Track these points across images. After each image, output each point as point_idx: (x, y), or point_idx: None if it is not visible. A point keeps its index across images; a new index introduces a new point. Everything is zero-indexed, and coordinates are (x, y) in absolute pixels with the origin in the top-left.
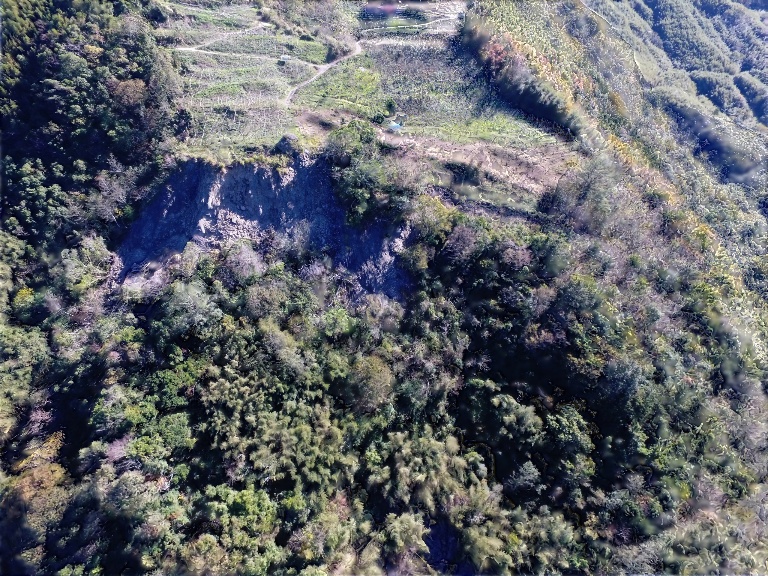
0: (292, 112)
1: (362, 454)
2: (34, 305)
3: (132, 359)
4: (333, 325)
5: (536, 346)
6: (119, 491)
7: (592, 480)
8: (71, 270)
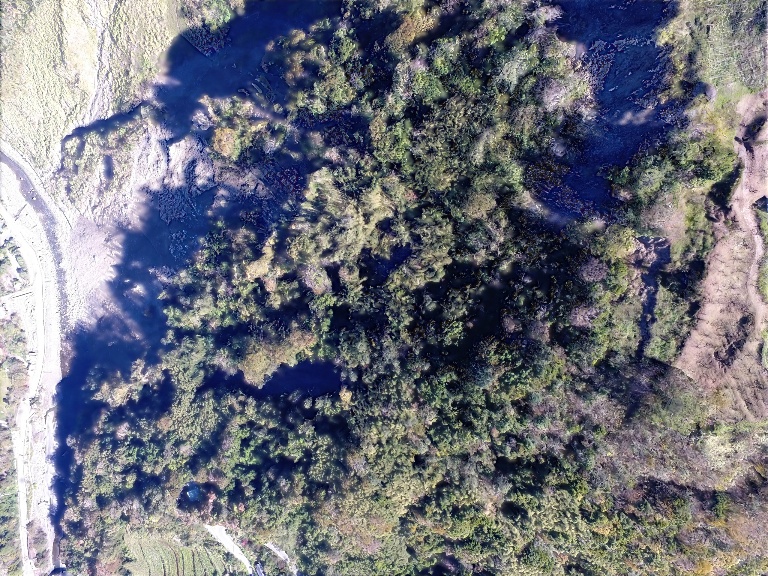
0: (765, 80)
1: (437, 203)
2: None
3: (472, 46)
4: None
5: None
6: (396, 76)
7: None
8: None
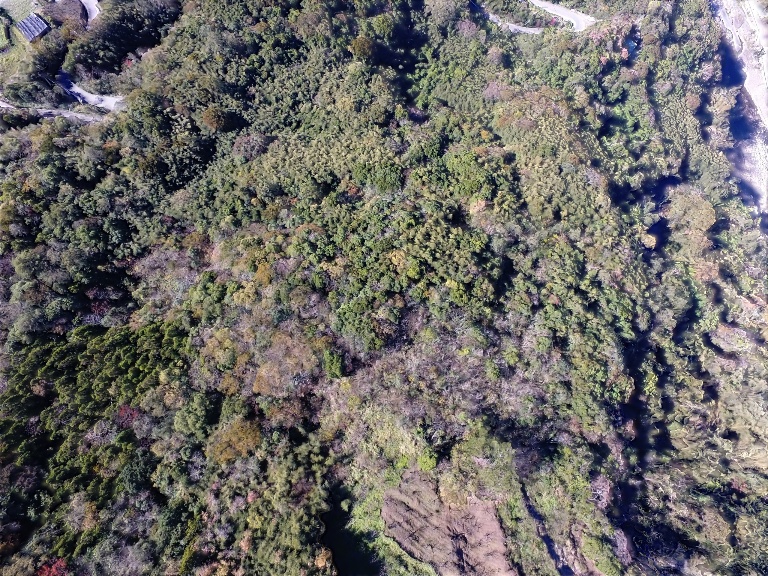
0: None
1: None
2: None
3: None
4: None
5: None
6: None
7: None
8: None
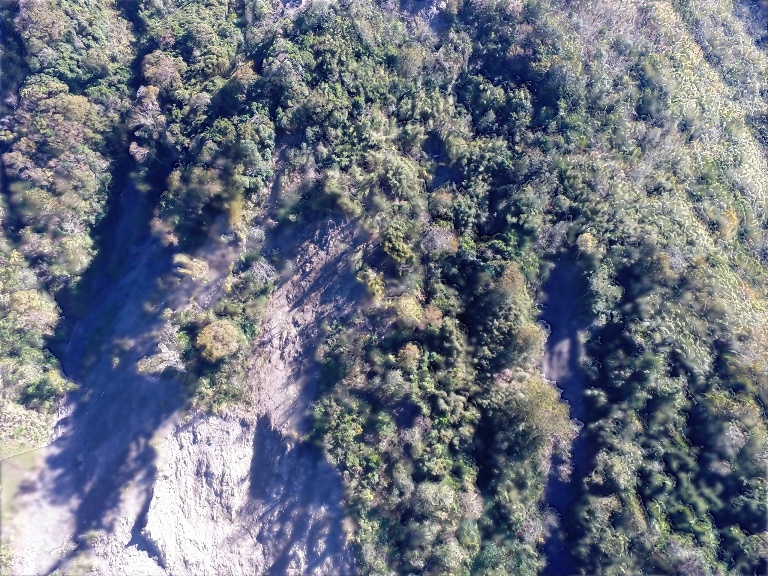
0: None
1: (399, 101)
2: (237, 23)
3: (289, 32)
4: (394, 30)
5: (513, 58)
6: (281, 71)
7: (528, 128)
8: (259, 0)
